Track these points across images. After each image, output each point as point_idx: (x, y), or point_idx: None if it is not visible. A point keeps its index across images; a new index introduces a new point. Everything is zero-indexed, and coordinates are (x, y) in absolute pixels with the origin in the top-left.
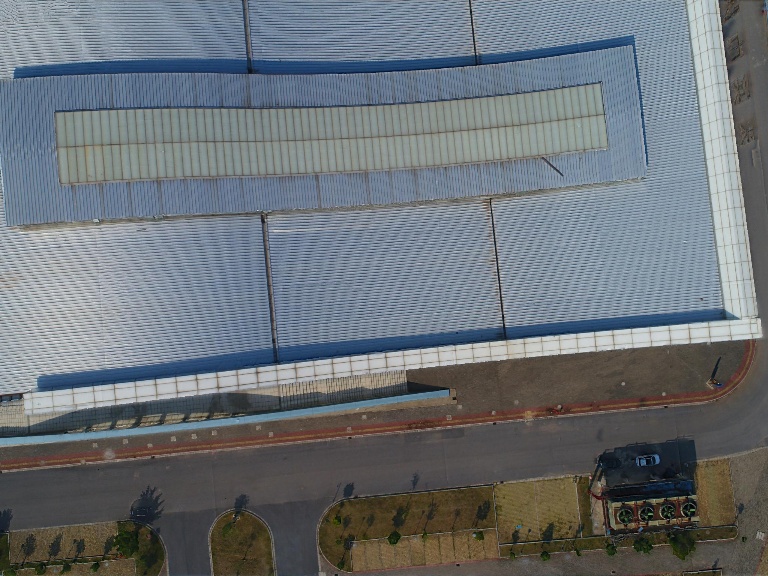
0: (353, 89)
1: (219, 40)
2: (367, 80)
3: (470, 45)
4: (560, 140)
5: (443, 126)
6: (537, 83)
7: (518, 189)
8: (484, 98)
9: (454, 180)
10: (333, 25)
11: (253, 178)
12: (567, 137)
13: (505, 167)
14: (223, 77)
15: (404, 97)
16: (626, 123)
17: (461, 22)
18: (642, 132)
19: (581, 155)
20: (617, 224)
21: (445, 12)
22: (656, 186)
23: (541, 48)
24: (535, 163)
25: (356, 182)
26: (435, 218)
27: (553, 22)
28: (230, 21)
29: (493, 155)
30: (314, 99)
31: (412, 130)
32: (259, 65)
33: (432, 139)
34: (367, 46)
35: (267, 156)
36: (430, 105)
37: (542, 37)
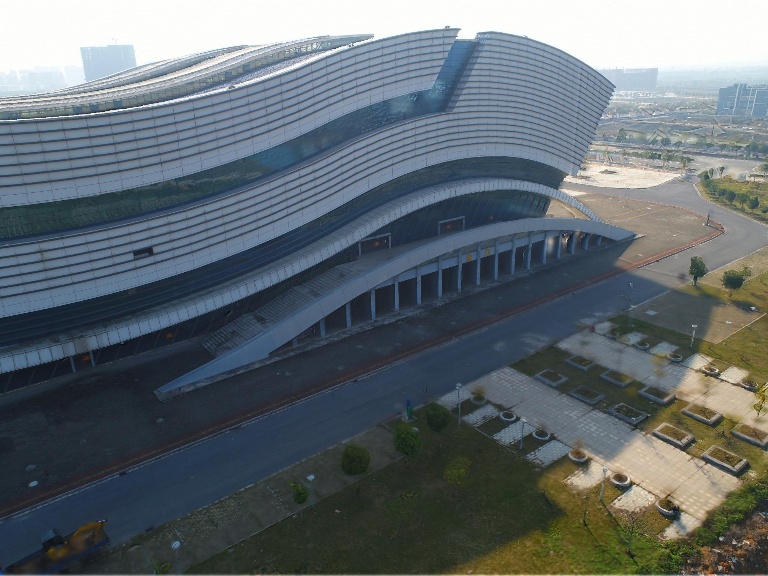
0: None
1: None
2: None
3: None
4: None
5: None
6: None
7: None
8: None
9: None
10: None
11: None
12: None
13: None
14: None
15: None
16: None
17: None
18: None
19: None
20: None
21: None
22: None
23: None
24: None
25: None
26: None
27: None
28: None
29: None
30: None
31: None
32: None
33: None
34: None
35: None
36: None
37: None
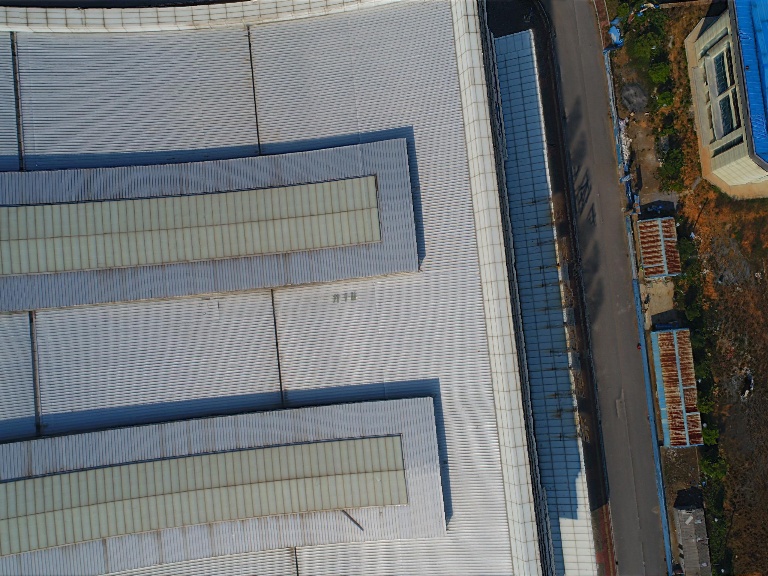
0: (146, 443)
1: (4, 400)
2: (161, 432)
3: (275, 380)
4: (360, 494)
5: (240, 478)
6: (338, 431)
7: (318, 543)
8: (283, 447)
9: (251, 534)
10: (131, 367)
11: (32, 552)
12: (367, 491)
13: (304, 519)
14: (1, 448)
15: (200, 447)
16: (425, 480)
17: (267, 356)
18: (441, 490)
19: (381, 509)
20: (422, 575)
21: (250, 346)
22: (460, 539)
23: (347, 385)
24: (335, 516)
25: (147, 541)
26: (237, 565)
27: (359, 359)
28: (17, 377)
29: (292, 507)
30: (103, 458)
31: (207, 484)
32: (49, 419)
33: (228, 492)
34: (167, 386)
35: (48, 527)
36: (227, 456)
37: (349, 374)
